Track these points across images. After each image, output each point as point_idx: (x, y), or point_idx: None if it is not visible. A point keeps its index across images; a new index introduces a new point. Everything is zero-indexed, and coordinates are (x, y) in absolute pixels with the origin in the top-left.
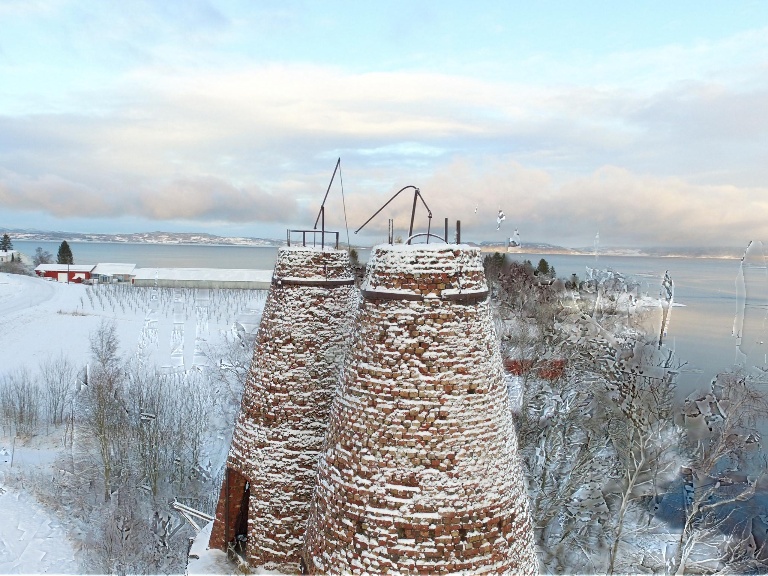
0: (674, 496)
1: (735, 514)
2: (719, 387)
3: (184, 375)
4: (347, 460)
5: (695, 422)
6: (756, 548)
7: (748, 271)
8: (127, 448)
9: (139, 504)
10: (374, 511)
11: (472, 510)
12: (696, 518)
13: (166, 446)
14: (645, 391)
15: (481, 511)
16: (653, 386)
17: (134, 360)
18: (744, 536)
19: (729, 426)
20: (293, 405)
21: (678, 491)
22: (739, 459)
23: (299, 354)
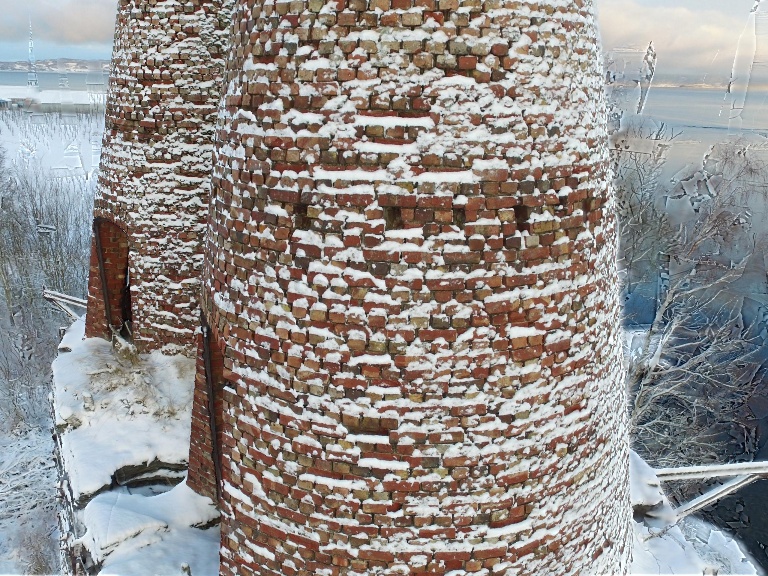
0: (647, 285)
1: (722, 295)
2: (713, 161)
3: (85, 180)
4: (267, 82)
5: (679, 204)
6: (743, 328)
7: (761, 21)
8: (26, 265)
9: (44, 322)
10: (331, 177)
11: (540, 168)
12: (677, 303)
13: (74, 261)
14: (629, 169)
15: (556, 172)
16: (639, 163)
17: (17, 160)
18: (731, 316)
19: (719, 205)
20: (184, 103)
21: (653, 279)
22: (724, 241)
23: (186, 15)
